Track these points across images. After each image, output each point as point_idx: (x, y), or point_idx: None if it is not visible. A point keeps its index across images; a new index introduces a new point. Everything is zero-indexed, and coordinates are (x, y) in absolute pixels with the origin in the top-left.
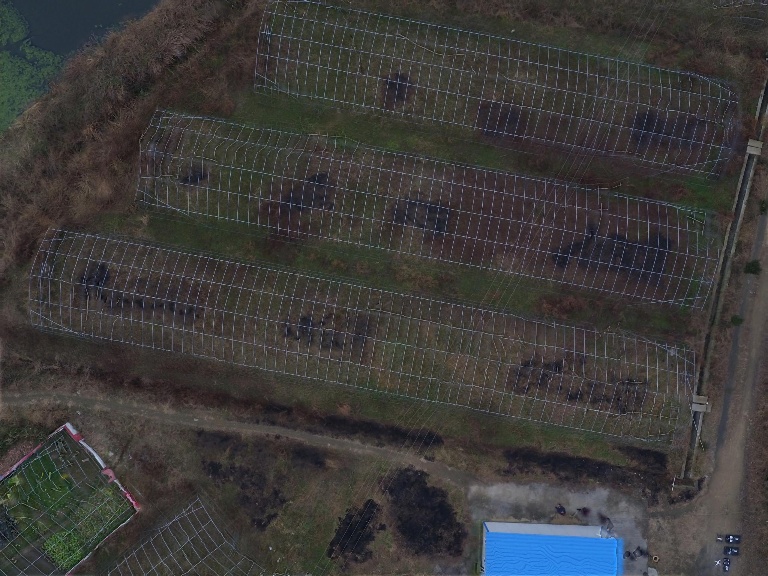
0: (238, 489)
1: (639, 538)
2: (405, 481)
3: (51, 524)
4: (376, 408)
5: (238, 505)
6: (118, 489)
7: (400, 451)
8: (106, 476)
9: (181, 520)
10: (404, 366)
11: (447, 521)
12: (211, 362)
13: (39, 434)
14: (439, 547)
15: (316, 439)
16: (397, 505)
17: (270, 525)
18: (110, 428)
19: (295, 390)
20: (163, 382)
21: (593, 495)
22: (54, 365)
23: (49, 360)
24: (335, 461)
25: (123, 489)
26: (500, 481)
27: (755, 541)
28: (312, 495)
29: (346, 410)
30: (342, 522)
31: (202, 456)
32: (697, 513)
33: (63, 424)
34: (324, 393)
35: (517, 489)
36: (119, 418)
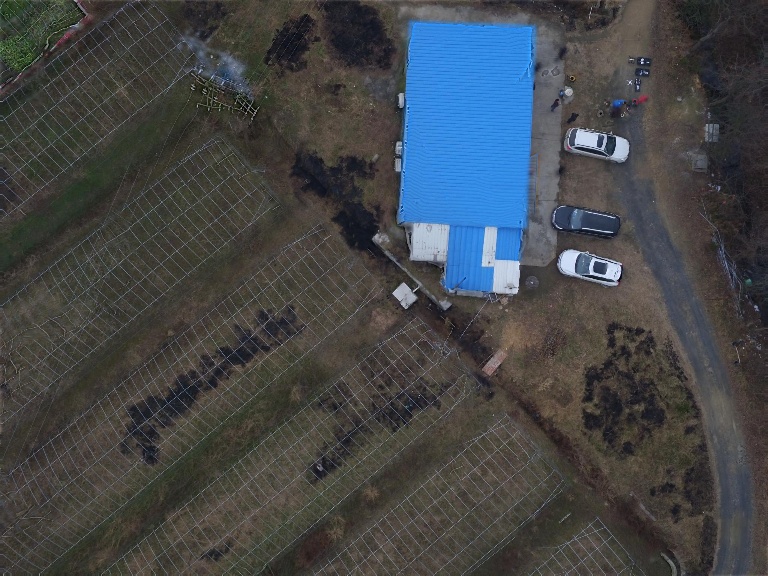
0: (183, 2)
1: (557, 58)
2: None
3: (5, 26)
4: None
5: (182, 16)
6: None
7: None
8: None
9: (127, 8)
10: None
11: (378, 36)
12: None
13: None
14: (370, 60)
15: None
16: (332, 20)
17: (212, 35)
18: None
19: None
20: None
21: (515, 19)
22: None
23: None
24: None
25: None
26: (429, 3)
27: (665, 65)
28: (252, 9)
29: None
30: (279, 33)
31: None
32: (611, 39)
33: None
34: None
35: (444, 11)
36: None
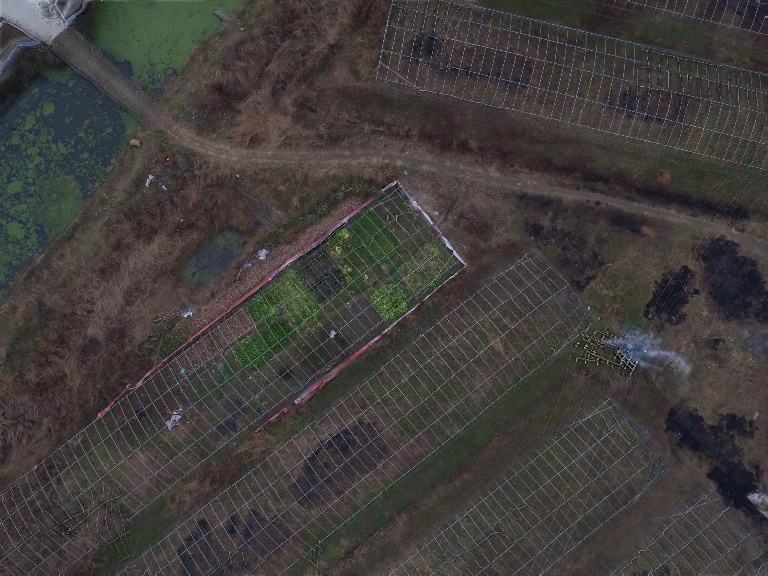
0: (559, 251)
1: None
2: (717, 250)
3: (381, 275)
4: (694, 177)
5: (559, 266)
6: (444, 246)
7: (712, 222)
8: (435, 231)
9: (519, 267)
10: (736, 128)
11: (756, 289)
12: (545, 123)
13: (372, 188)
14: (748, 313)
15: (634, 207)
16: (710, 272)
17: (589, 286)
18: (437, 188)
19: (618, 157)
20: (491, 145)
21: None
22: (381, 127)
23: (376, 123)
24: (650, 229)
25: (450, 245)
26: None
27: None
28: (630, 259)
29: (664, 179)
30: (658, 285)
31: (525, 218)
32: None
33: (392, 182)
34: (651, 157)
35: None
36: (445, 179)
